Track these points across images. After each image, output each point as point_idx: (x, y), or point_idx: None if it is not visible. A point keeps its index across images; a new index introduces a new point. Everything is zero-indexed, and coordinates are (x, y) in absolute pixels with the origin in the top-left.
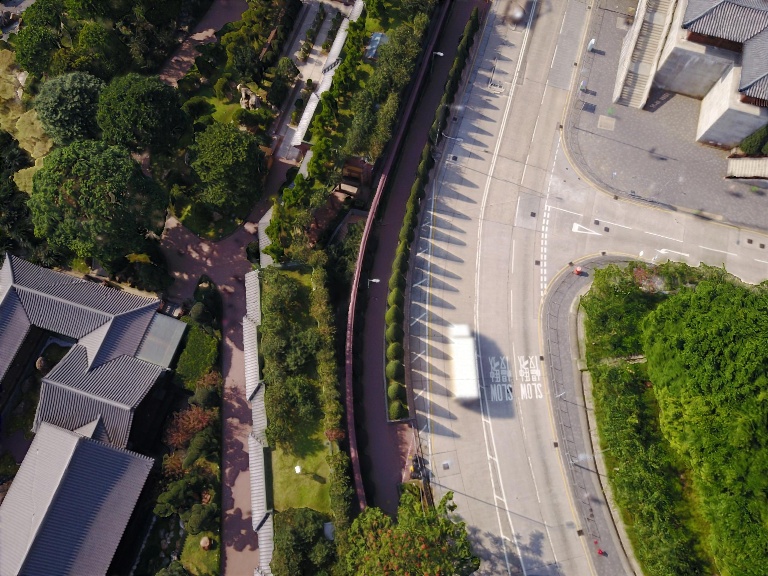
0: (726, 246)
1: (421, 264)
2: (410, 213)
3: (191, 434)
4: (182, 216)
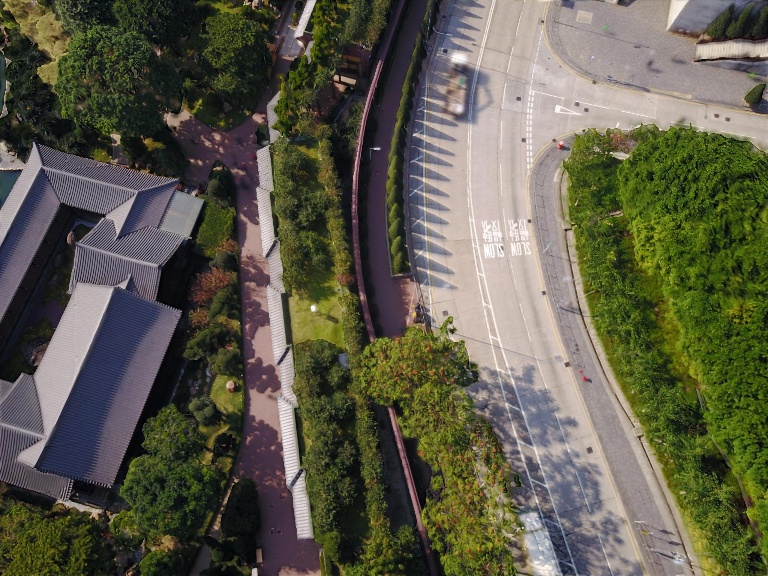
0: (695, 121)
1: (417, 143)
2: (406, 93)
3: (213, 292)
4: (194, 109)
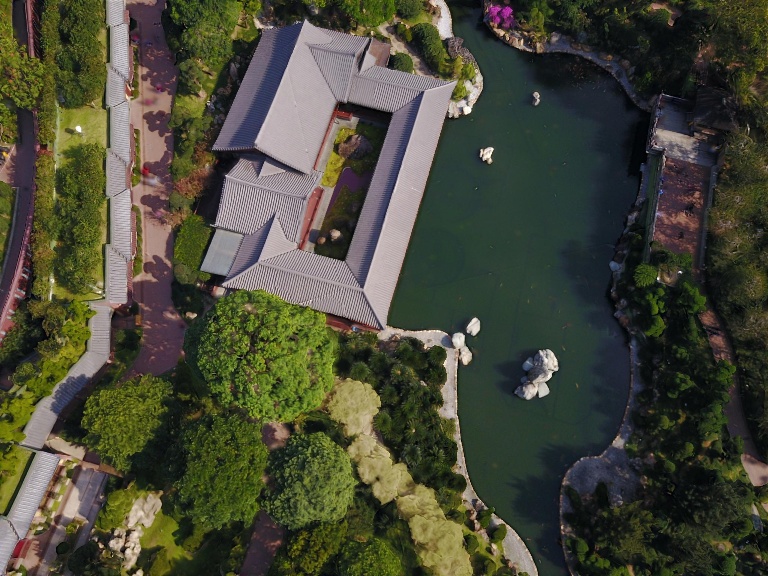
0: None
1: None
2: None
3: None
4: None
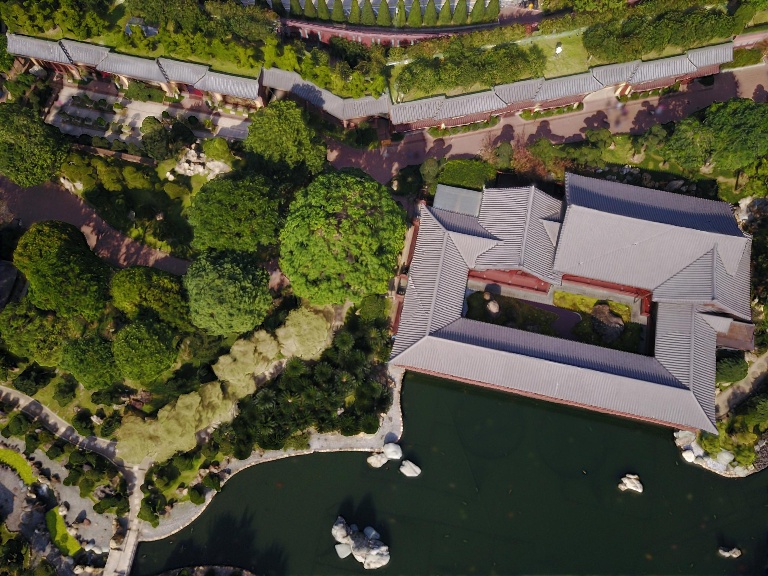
0: None
1: None
2: (324, 2)
3: None
4: None
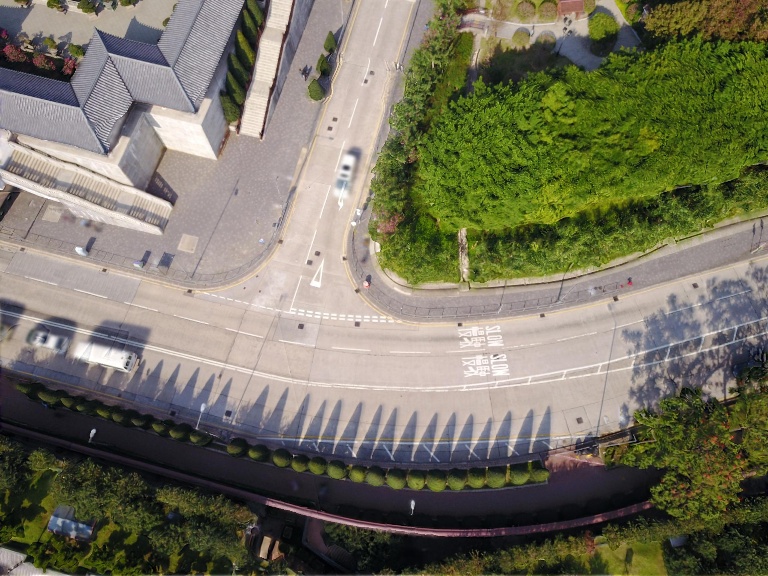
0: (335, 149)
1: (366, 452)
2: (318, 467)
3: None
4: None
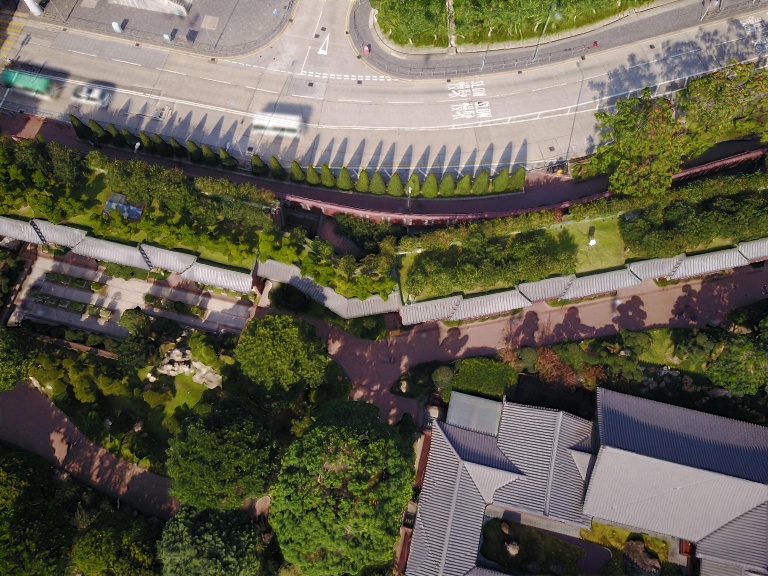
0: None
1: (369, 175)
2: (329, 171)
3: None
4: None
